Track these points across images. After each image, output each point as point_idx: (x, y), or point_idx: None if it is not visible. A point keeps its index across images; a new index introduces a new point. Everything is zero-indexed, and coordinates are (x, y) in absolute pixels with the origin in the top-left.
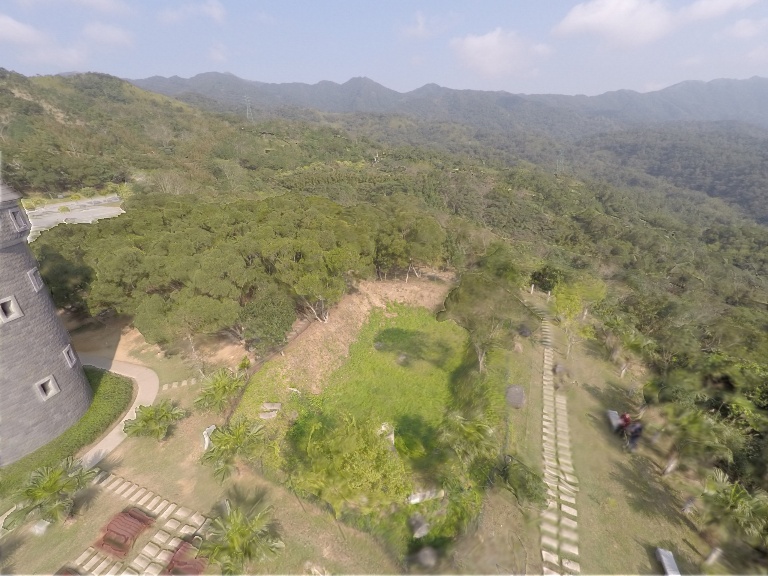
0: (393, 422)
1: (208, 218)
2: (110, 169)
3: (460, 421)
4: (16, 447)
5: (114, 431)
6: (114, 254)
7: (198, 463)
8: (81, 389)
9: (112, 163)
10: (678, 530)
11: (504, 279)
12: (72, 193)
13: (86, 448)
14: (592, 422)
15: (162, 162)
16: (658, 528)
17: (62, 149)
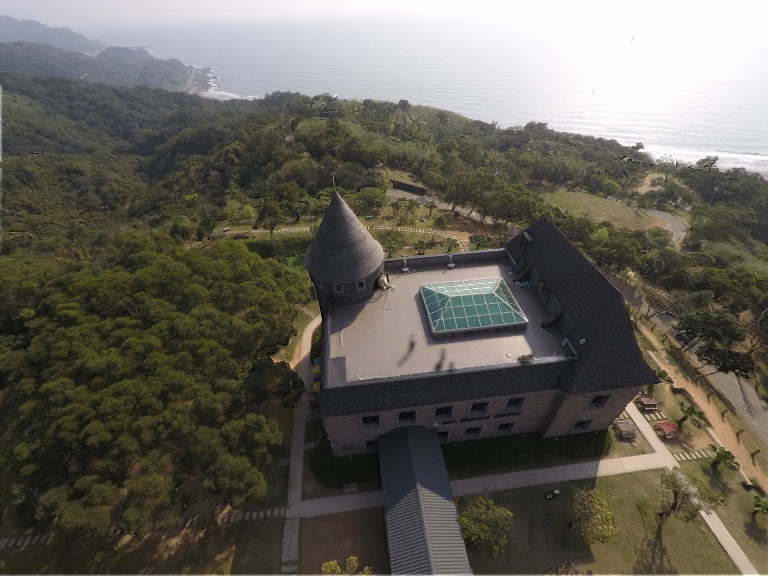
0: (297, 266)
1: None
2: None
3: (312, 230)
4: None
5: None
6: None
7: None
8: None
9: None
10: (318, 218)
11: (207, 228)
12: None
13: None
14: (291, 224)
15: None
16: (320, 219)
17: None
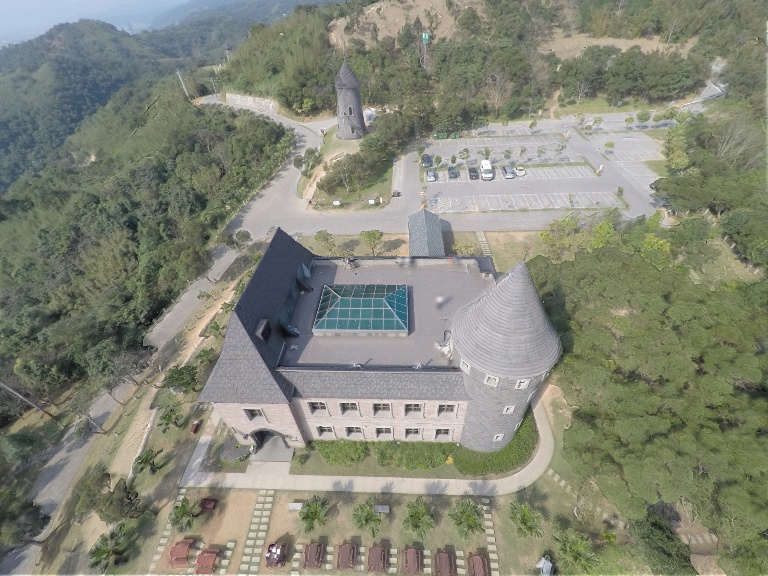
0: None
1: (714, 339)
2: (689, 76)
3: None
4: (472, 445)
5: (508, 479)
6: (595, 344)
7: (527, 571)
8: (511, 438)
9: (698, 65)
10: None
11: None
12: (632, 100)
13: (492, 475)
14: None
15: (762, 76)
16: None
17: (661, 27)
